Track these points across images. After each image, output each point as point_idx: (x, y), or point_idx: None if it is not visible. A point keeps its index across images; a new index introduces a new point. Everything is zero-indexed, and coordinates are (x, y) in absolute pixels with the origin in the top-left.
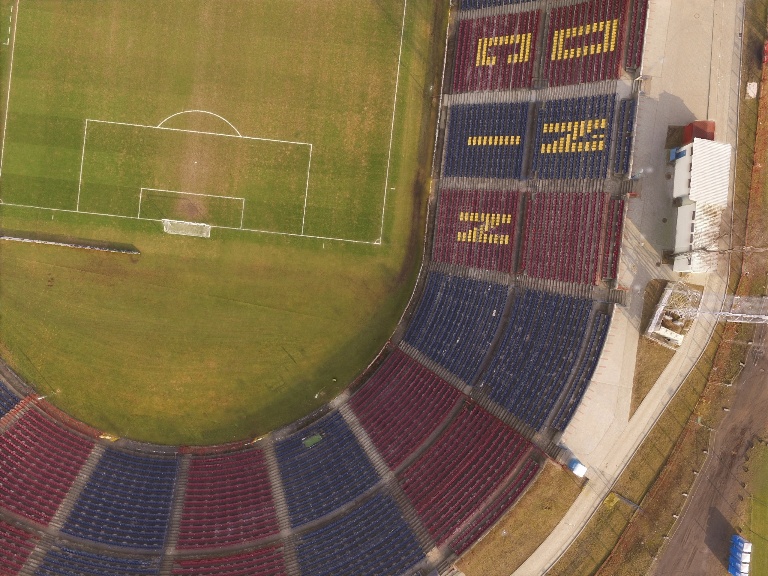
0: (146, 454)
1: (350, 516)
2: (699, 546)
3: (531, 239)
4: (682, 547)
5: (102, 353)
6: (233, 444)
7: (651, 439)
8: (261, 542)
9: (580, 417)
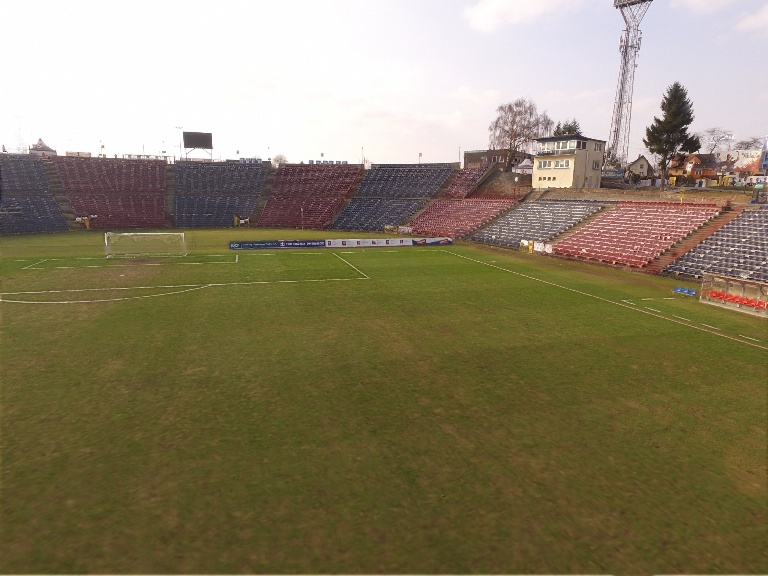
0: None
1: None
2: None
3: None
4: None
5: None
6: None
7: None
8: None
9: None
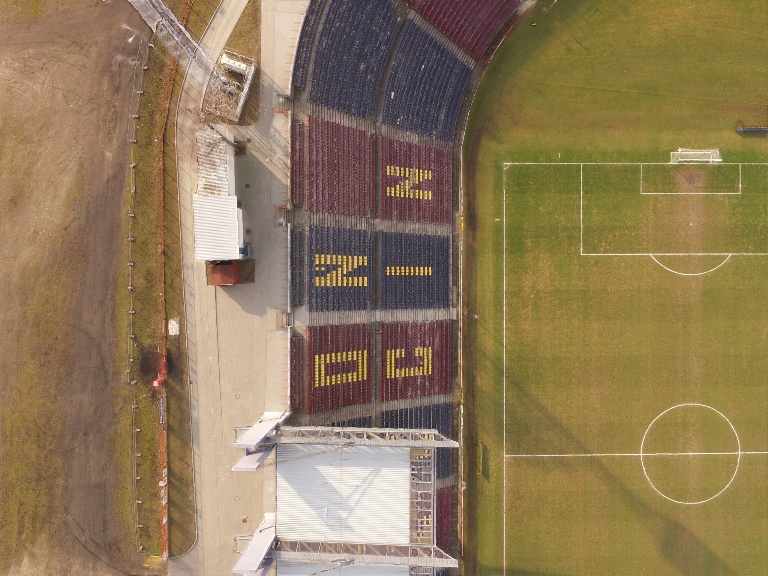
0: None
1: None
2: None
3: (367, 169)
4: None
5: (762, 29)
6: None
7: None
8: None
9: None
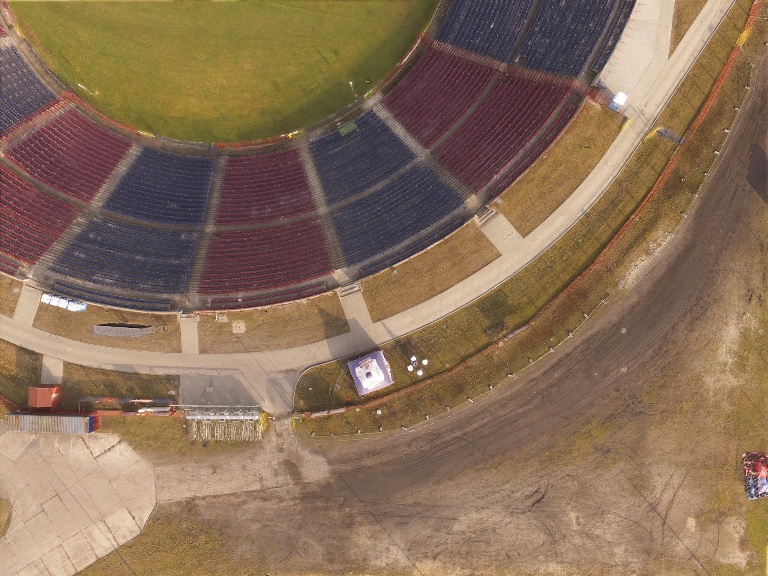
0: (183, 154)
1: (386, 189)
2: (741, 183)
3: None
4: (723, 184)
5: (139, 55)
6: (268, 147)
7: (691, 77)
8: (298, 220)
9: (619, 55)
